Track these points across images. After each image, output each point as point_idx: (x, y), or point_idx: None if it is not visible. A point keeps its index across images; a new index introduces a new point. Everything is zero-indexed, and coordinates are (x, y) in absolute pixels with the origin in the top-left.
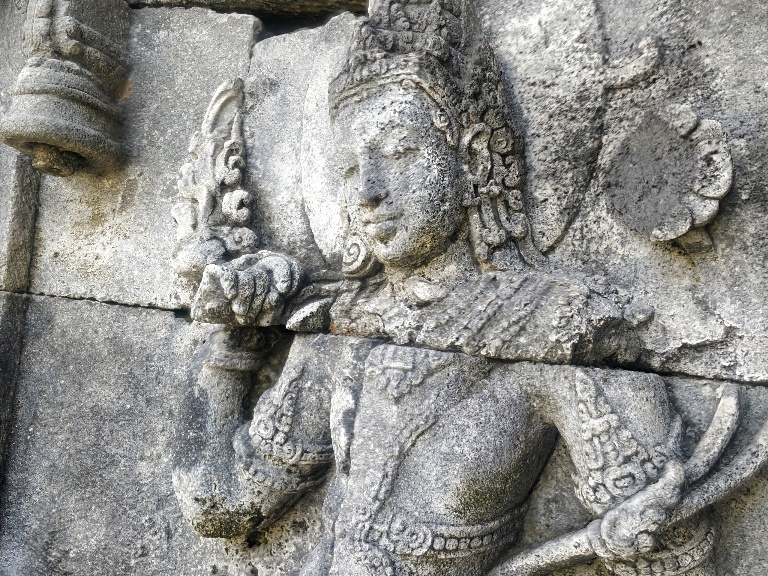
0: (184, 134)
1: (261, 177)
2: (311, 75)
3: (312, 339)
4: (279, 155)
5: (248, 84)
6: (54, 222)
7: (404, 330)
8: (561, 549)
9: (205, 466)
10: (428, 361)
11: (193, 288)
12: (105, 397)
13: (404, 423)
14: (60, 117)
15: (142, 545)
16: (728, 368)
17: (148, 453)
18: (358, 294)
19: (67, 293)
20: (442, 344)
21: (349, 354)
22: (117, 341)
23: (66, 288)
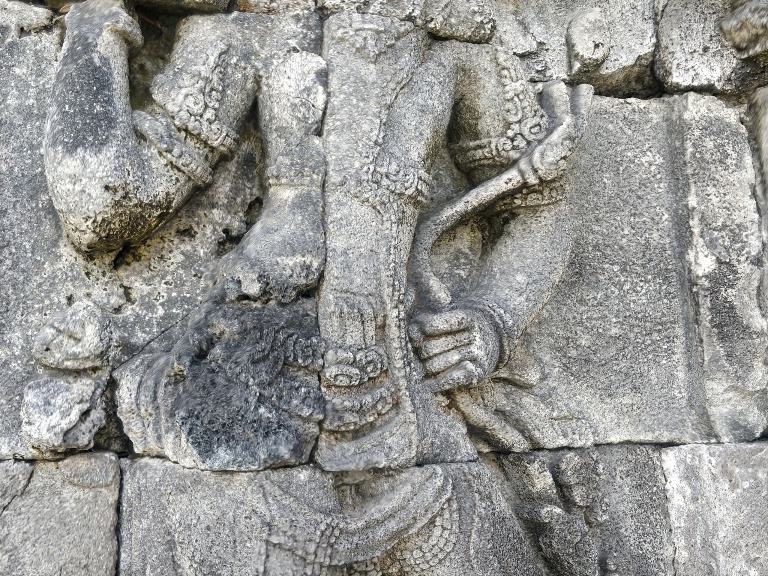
0: None
1: None
2: None
3: (226, 16)
4: None
5: None
6: None
7: (351, 4)
8: (492, 189)
9: (118, 147)
10: (395, 26)
11: None
12: None
13: (391, 76)
14: None
15: None
16: (539, 73)
17: None
18: None
19: None
20: (399, 15)
21: (292, 25)
22: None
23: None
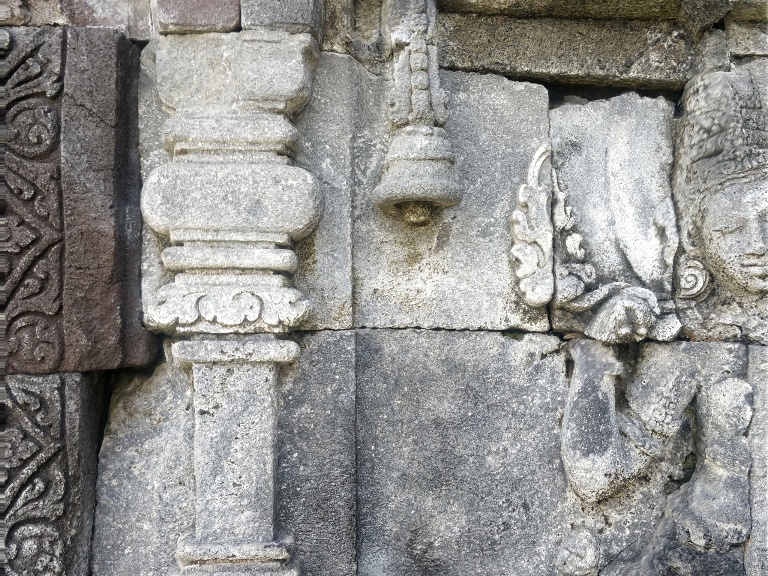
0: (494, 183)
1: (579, 221)
2: (611, 141)
3: (677, 346)
4: (591, 203)
5: (556, 145)
6: (369, 262)
7: None
8: None
9: (613, 449)
10: None
11: (523, 312)
12: (446, 409)
13: None
14: (452, 180)
15: (503, 522)
16: None
17: (493, 449)
18: (698, 310)
19: (392, 324)
20: None
21: (726, 355)
22: (450, 361)
23: (391, 320)
